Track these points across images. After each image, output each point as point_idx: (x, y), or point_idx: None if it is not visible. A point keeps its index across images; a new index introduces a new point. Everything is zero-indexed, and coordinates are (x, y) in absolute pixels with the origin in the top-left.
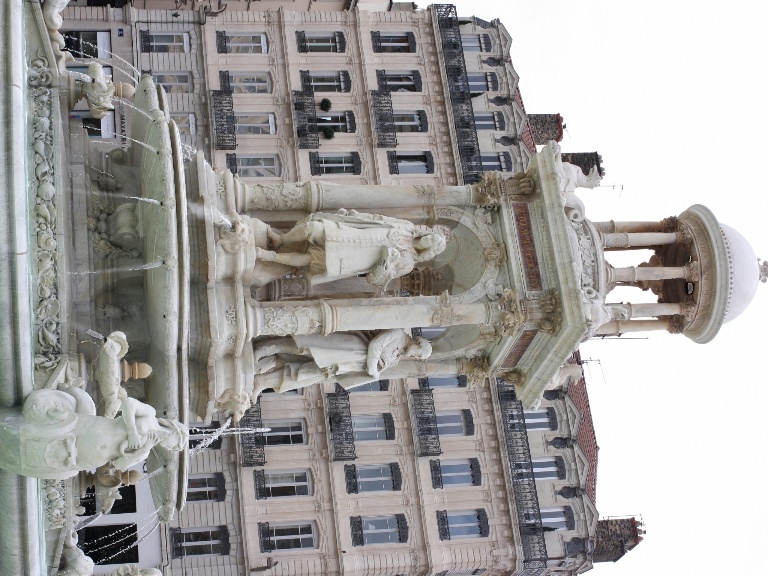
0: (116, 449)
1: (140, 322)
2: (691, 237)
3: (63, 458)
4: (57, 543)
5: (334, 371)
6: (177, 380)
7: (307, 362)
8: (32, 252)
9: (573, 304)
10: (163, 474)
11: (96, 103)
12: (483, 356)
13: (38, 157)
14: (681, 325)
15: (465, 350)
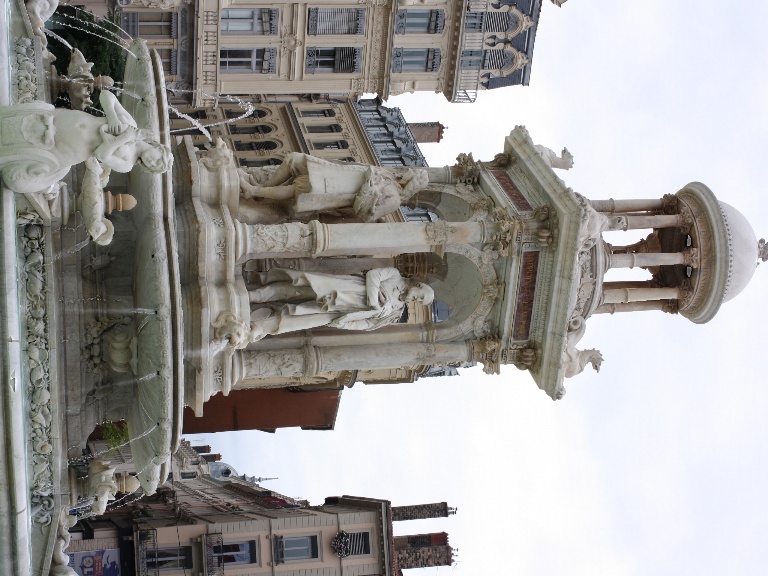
0: (96, 132)
1: (125, 222)
2: (675, 196)
3: (41, 132)
4: (45, 552)
5: (333, 301)
6: (164, 236)
7: (304, 302)
8: (13, 91)
9: (565, 200)
10: (155, 328)
11: (76, 74)
12: (493, 334)
13: (20, 55)
14: (691, 288)
15: (472, 323)
